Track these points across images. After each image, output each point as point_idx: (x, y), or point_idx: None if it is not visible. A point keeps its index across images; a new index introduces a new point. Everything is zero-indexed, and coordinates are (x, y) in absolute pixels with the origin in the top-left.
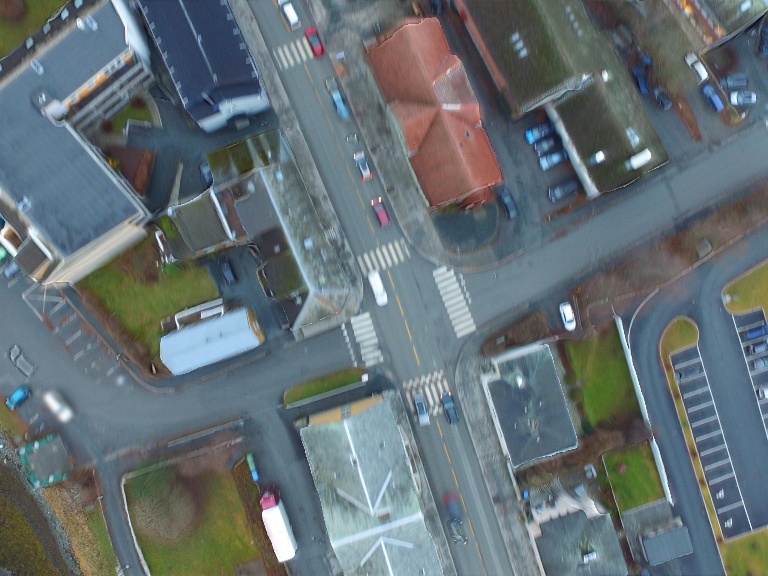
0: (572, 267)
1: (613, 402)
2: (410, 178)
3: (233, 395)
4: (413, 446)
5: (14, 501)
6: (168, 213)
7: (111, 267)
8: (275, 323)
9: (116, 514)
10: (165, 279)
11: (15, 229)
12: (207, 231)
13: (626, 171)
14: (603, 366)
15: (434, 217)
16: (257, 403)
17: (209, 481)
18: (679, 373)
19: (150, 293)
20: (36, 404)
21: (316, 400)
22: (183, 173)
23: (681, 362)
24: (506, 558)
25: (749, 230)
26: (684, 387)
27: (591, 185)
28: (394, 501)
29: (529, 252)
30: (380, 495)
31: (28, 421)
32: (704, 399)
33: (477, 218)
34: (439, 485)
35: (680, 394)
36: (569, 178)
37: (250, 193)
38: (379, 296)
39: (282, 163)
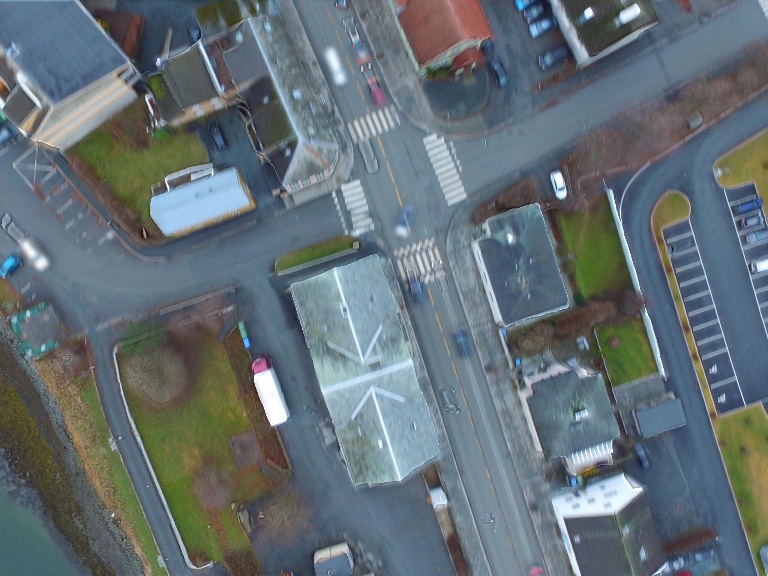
0: (563, 136)
1: (605, 276)
2: (399, 42)
3: (224, 264)
4: (405, 314)
5: (7, 377)
6: (156, 63)
7: (101, 131)
8: (266, 189)
9: (108, 384)
10: (155, 145)
11: (4, 79)
12: (196, 86)
13: (615, 28)
14: (595, 240)
15: (424, 83)
16: (248, 272)
17: (201, 351)
18: (671, 246)
19: (140, 159)
20: (28, 273)
21: (307, 267)
22: (172, 38)
23: (673, 236)
24: (499, 427)
25: (740, 103)
26: (676, 261)
27: (581, 48)
28: (384, 350)
29: (519, 121)
30: (370, 346)
31: (20, 291)
32: (696, 273)
33: (467, 85)
34: (431, 354)
35: (672, 268)
36: (559, 45)
37: (238, 44)
38: (369, 163)
39: (270, 15)
